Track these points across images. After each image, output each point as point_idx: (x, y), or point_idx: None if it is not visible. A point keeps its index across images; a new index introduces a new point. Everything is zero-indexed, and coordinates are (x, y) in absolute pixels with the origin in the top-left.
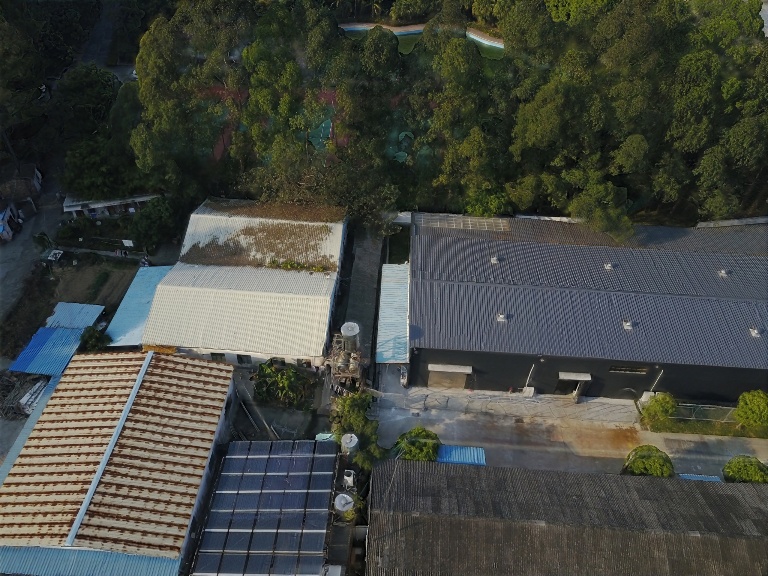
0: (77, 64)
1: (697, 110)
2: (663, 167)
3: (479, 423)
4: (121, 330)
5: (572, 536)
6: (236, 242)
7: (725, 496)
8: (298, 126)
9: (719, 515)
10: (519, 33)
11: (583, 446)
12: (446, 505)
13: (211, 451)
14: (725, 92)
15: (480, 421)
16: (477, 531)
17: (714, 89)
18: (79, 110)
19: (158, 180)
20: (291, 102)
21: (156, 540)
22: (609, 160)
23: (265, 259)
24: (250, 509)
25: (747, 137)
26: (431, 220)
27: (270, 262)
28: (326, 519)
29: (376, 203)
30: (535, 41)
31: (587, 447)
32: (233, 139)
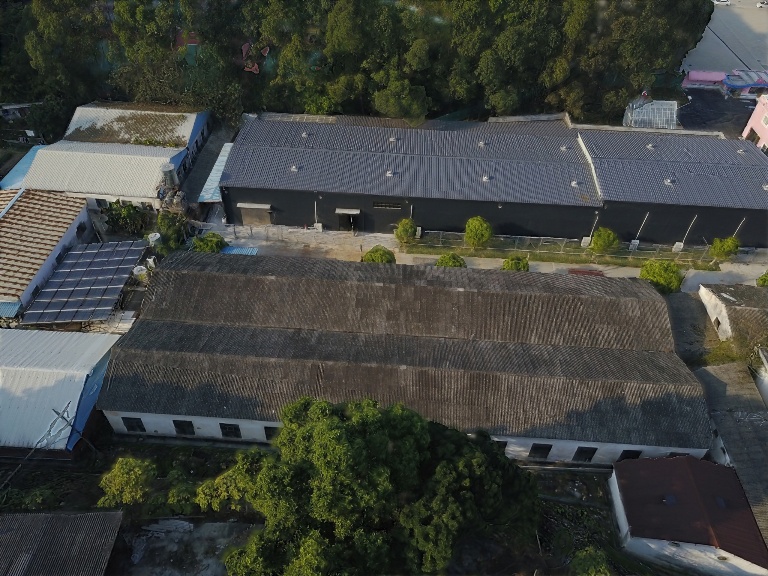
0: (7, 5)
1: (470, 20)
2: (455, 70)
3: (275, 247)
4: (9, 183)
5: (292, 285)
6: (110, 127)
7: (419, 271)
8: (152, 31)
9: (406, 278)
10: None
11: None
12: (209, 269)
13: (59, 251)
14: (492, 6)
15: (277, 246)
16: (226, 282)
17: (484, 4)
18: (2, 37)
19: (51, 81)
20: (145, 11)
21: (3, 290)
22: (405, 62)
23: (131, 138)
24: (76, 278)
25: (509, 41)
26: (274, 116)
27: (134, 140)
28: (125, 280)
29: (223, 97)
30: None
31: None
32: (110, 47)
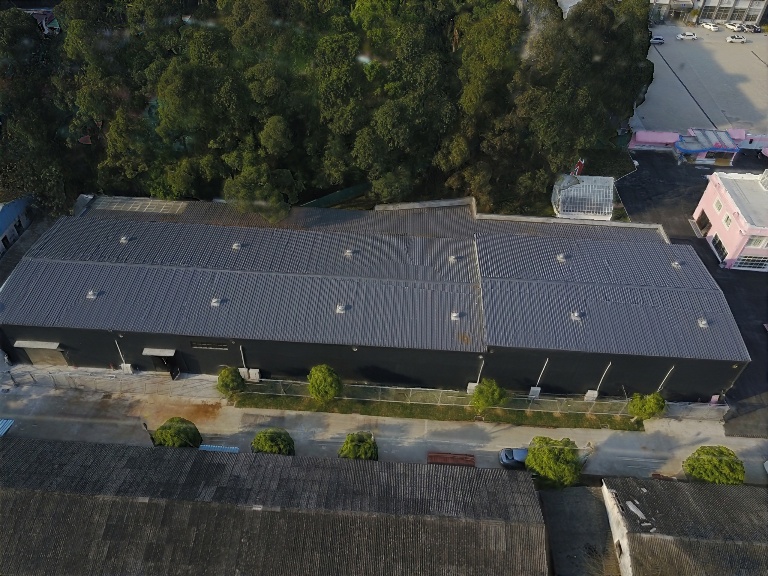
0: None
1: (341, 92)
2: (329, 149)
3: (64, 399)
4: None
5: (19, 502)
6: None
7: (216, 465)
8: None
9: (189, 483)
10: (139, 14)
11: (156, 421)
12: None
13: None
14: (368, 74)
15: (67, 397)
16: None
17: (358, 71)
18: None
19: None
20: None
21: None
22: None
23: None
24: None
25: (388, 118)
26: (110, 203)
27: None
28: None
29: (35, 185)
30: (151, 22)
31: (160, 422)
32: None
